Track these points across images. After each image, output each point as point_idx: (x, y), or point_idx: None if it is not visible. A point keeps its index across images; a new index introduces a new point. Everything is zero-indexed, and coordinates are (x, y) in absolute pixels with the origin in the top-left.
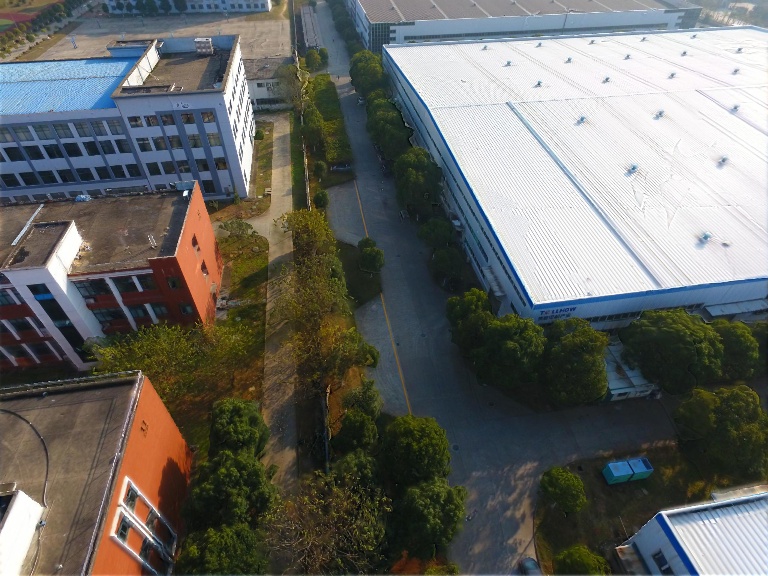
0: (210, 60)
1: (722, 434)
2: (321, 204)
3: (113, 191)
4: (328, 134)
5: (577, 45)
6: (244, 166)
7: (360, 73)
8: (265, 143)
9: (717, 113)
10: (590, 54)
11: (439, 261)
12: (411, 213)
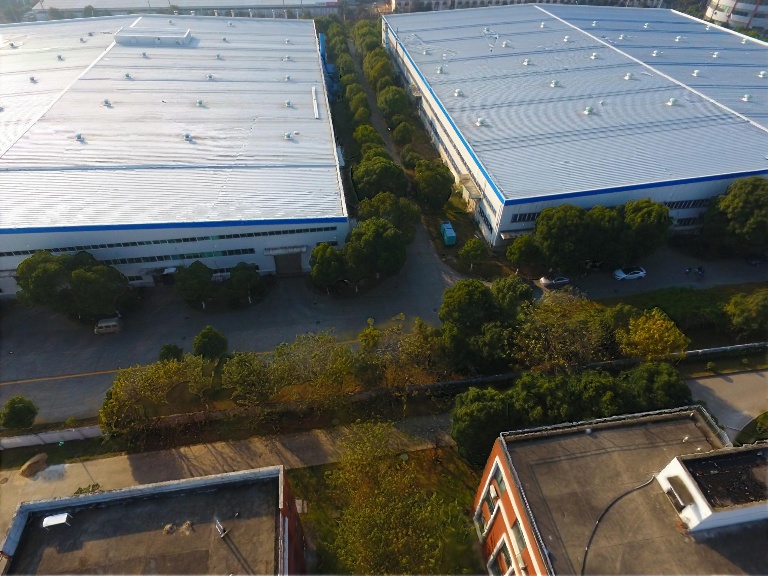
0: None
1: (445, 180)
2: (30, 414)
3: None
4: None
5: None
6: None
7: None
8: None
9: (127, 84)
10: None
11: (245, 282)
12: (108, 317)
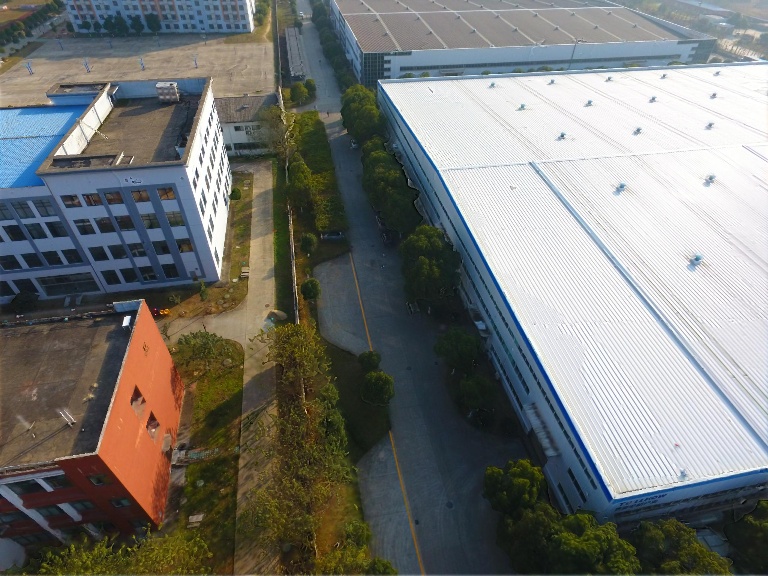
0: (175, 109)
1: None
2: (310, 295)
3: (47, 280)
4: (317, 192)
5: (593, 82)
6: (215, 243)
7: (353, 115)
8: (243, 202)
9: None
10: (610, 95)
11: (466, 395)
12: (421, 304)
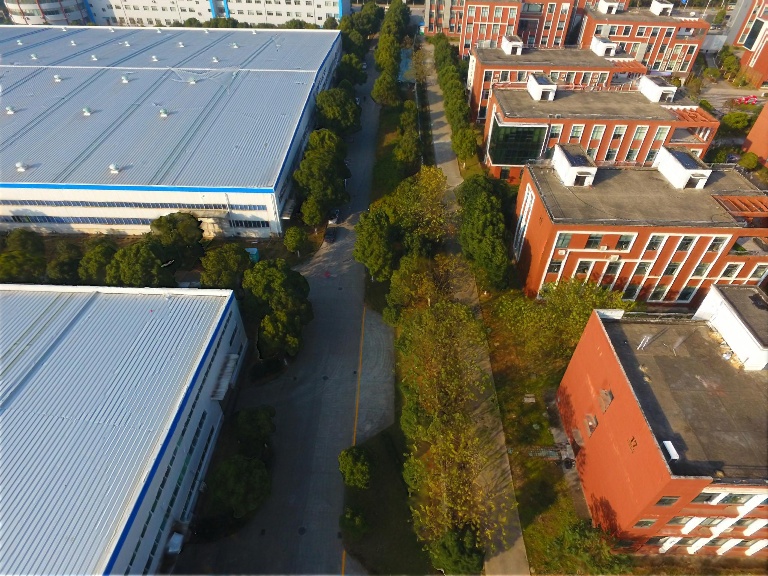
0: None
1: None
2: None
3: None
4: None
5: None
6: None
7: None
8: None
9: None
10: None
11: None
12: None
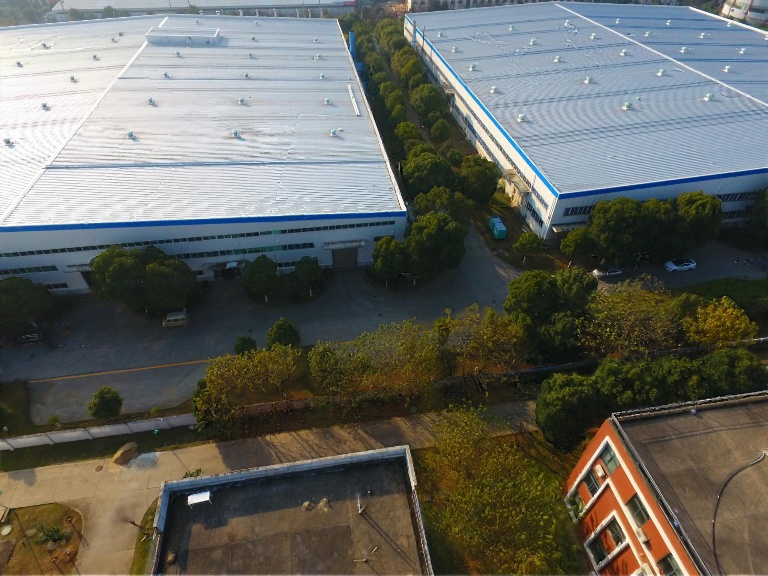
0: None
1: (493, 175)
2: (118, 404)
3: None
4: None
5: None
6: None
7: None
8: None
9: (166, 83)
10: None
11: (310, 275)
12: None
